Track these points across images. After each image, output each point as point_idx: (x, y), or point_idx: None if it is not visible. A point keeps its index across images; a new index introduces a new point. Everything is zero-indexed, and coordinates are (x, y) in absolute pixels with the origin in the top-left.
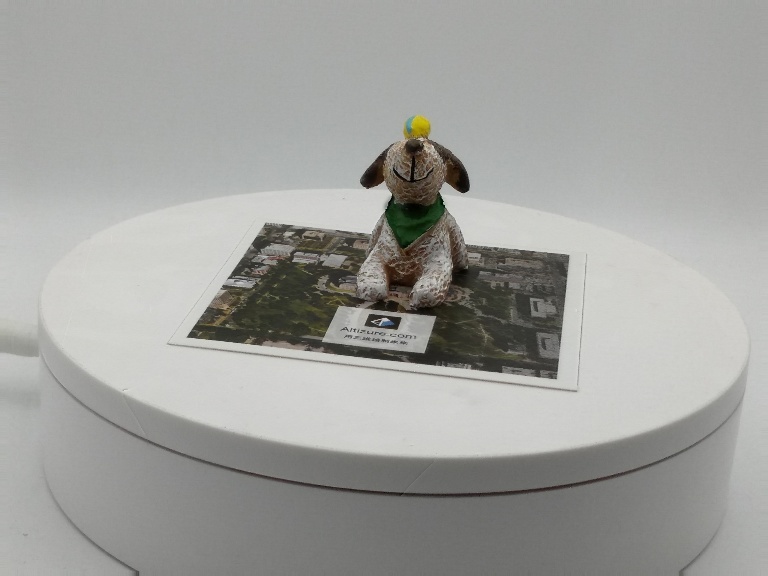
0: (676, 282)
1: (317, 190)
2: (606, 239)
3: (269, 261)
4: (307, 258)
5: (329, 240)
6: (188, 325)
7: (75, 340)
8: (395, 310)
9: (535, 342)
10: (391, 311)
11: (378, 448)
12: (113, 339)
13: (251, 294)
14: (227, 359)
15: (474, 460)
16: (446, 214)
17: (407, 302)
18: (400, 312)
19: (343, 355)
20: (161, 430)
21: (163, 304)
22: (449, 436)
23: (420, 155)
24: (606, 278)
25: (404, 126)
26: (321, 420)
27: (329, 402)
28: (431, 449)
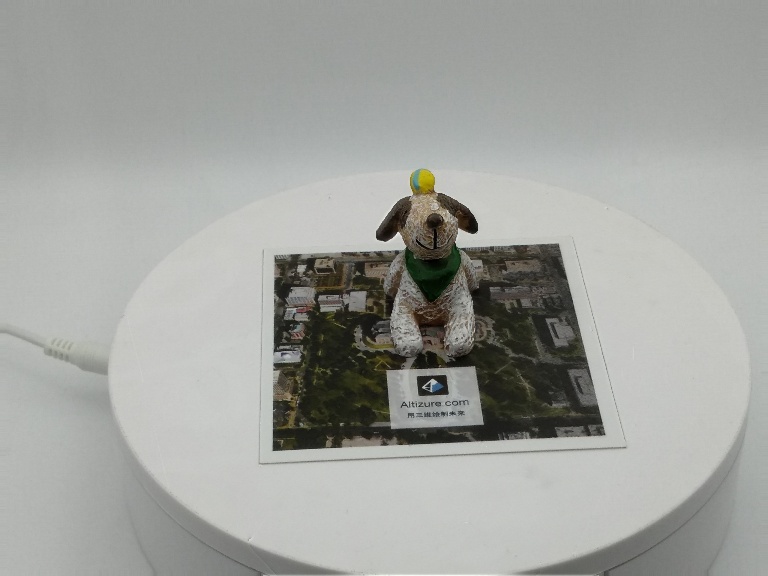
0: (661, 263)
1: (300, 188)
2: (582, 209)
3: (300, 316)
4: (332, 303)
5: (341, 270)
6: (267, 432)
7: (176, 478)
8: (437, 365)
9: (571, 385)
10: (434, 368)
11: (490, 567)
12: (209, 468)
13: (304, 372)
14: (319, 473)
15: (572, 562)
16: (460, 256)
17: (443, 351)
18: (442, 367)
19: (416, 444)
20: (292, 573)
21: (231, 404)
22: (542, 536)
23: (441, 227)
24: (600, 271)
25: (411, 183)
26: (430, 541)
27: (428, 513)
28: (534, 557)
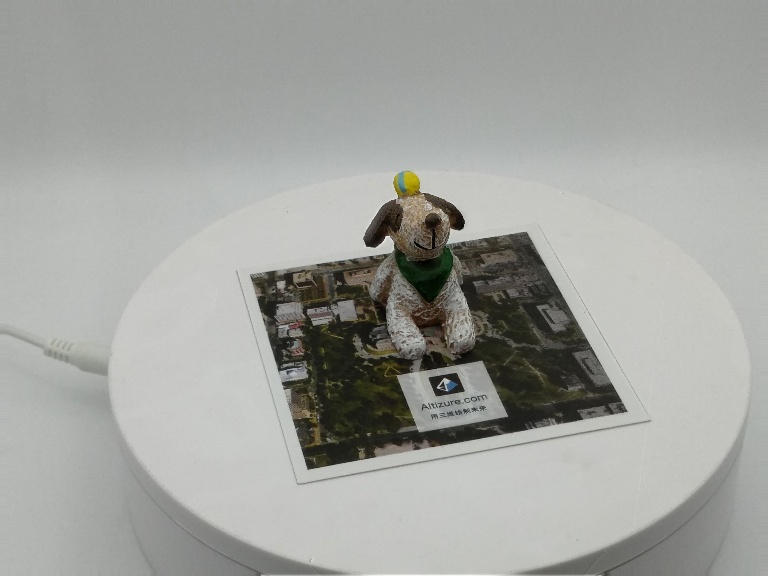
0: (629, 240)
1: (254, 205)
2: (539, 196)
3: (294, 332)
4: (322, 316)
5: (321, 282)
6: (296, 452)
7: (218, 509)
8: (445, 364)
9: (580, 367)
10: (442, 367)
11: (556, 555)
12: (249, 496)
13: (315, 387)
14: (360, 485)
15: (632, 538)
16: None
17: (446, 349)
18: (450, 366)
19: (448, 444)
20: None
21: (251, 428)
22: (597, 517)
23: None
24: (574, 254)
25: (396, 186)
26: (491, 537)
27: (480, 511)
28: (595, 539)
